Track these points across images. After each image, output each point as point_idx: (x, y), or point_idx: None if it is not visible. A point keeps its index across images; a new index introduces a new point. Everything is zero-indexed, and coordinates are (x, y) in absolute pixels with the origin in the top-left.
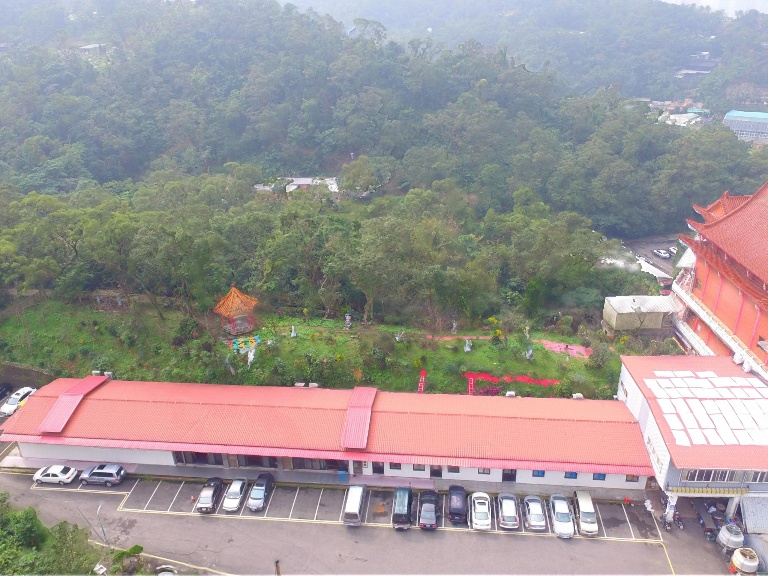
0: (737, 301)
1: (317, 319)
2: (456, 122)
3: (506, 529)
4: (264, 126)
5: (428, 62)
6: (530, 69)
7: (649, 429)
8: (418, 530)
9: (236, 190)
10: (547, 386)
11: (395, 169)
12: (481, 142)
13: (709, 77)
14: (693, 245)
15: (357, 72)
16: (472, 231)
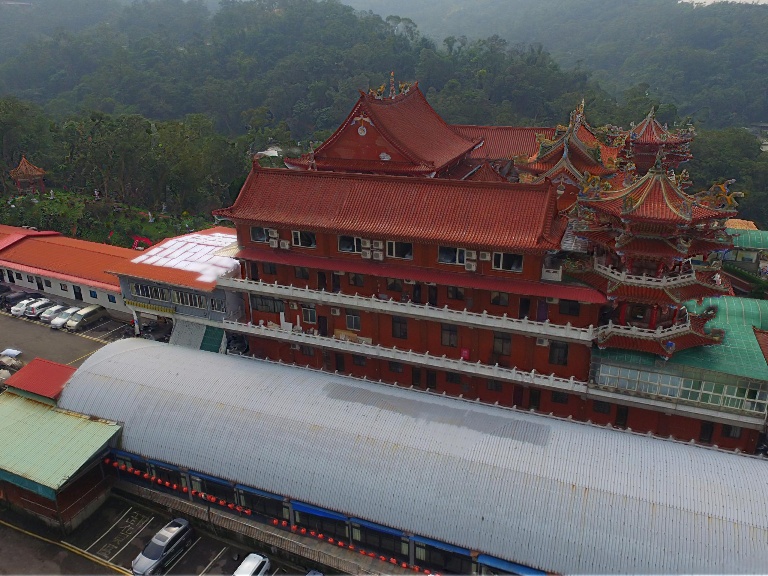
0: None
1: (88, 195)
2: None
3: (28, 317)
4: (271, 100)
5: (453, 58)
6: None
7: None
8: None
9: None
10: None
11: None
12: None
13: None
14: None
15: (372, 61)
16: None
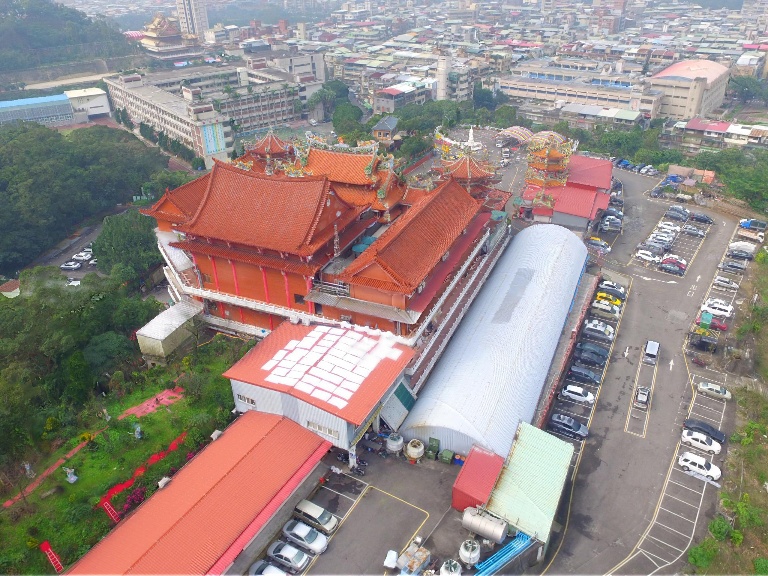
0: (259, 276)
1: None
2: None
3: None
4: None
5: None
6: None
7: (305, 414)
8: None
9: None
10: (177, 448)
11: None
12: None
13: None
14: (188, 247)
15: None
16: None
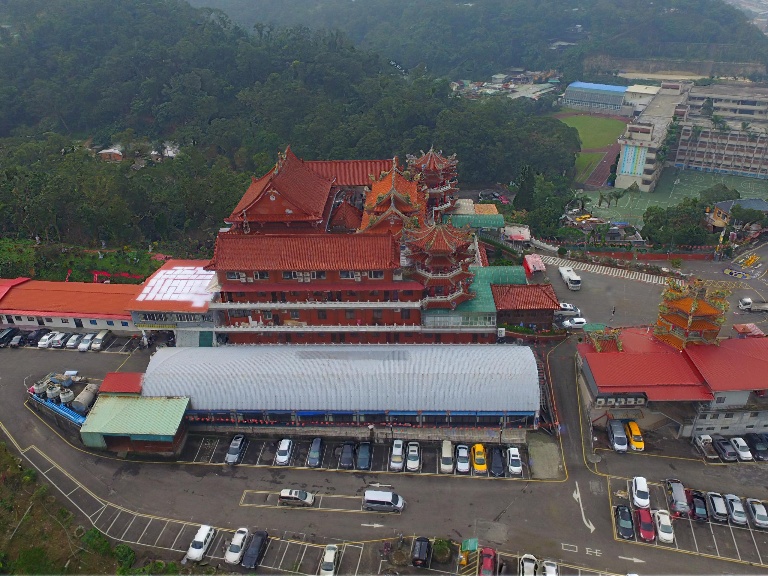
0: None
1: (24, 239)
2: (256, 98)
3: (55, 347)
4: (108, 101)
5: (266, 44)
6: (419, 41)
7: None
8: (10, 348)
9: (46, 153)
10: None
11: (199, 137)
12: (275, 115)
13: (570, 50)
14: None
15: (195, 54)
16: None
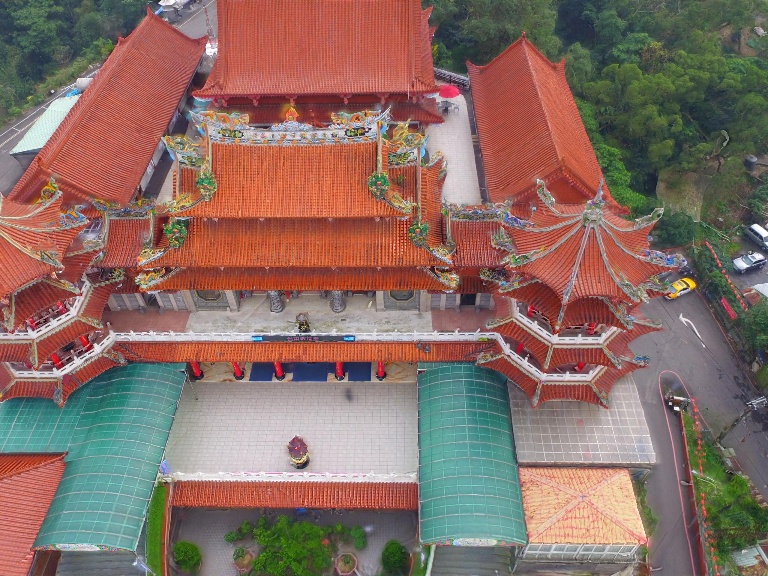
0: None
1: None
2: None
3: None
4: None
5: None
6: None
7: None
8: None
9: None
10: None
11: None
12: None
13: None
14: None
15: None
16: (684, 48)
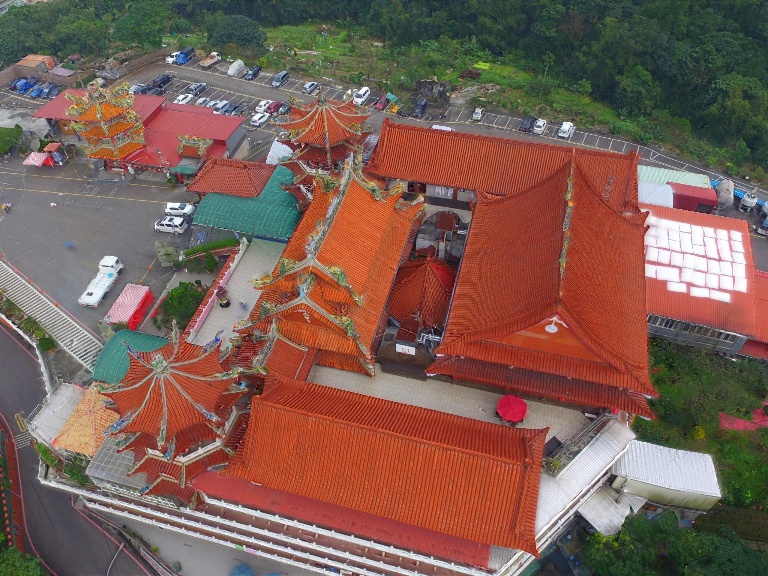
0: None
1: None
2: None
3: None
4: None
5: None
6: None
7: None
8: None
9: None
10: None
11: None
12: None
13: None
14: None
15: None
16: None
